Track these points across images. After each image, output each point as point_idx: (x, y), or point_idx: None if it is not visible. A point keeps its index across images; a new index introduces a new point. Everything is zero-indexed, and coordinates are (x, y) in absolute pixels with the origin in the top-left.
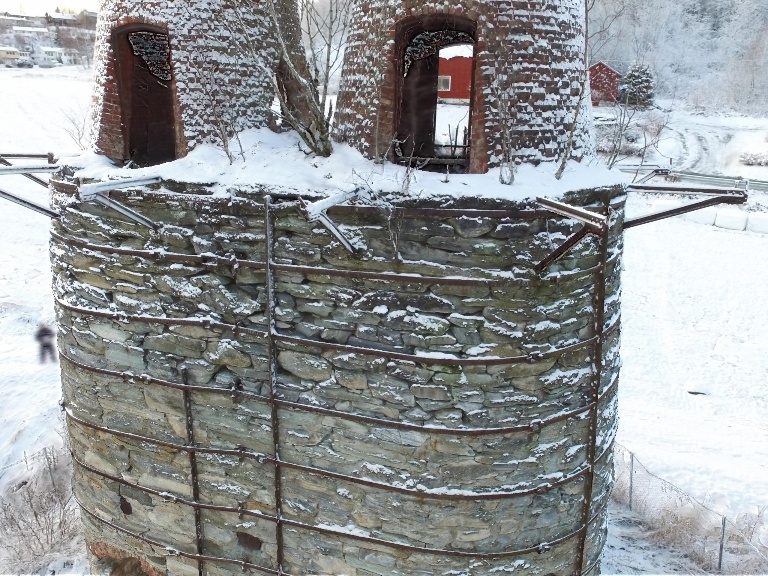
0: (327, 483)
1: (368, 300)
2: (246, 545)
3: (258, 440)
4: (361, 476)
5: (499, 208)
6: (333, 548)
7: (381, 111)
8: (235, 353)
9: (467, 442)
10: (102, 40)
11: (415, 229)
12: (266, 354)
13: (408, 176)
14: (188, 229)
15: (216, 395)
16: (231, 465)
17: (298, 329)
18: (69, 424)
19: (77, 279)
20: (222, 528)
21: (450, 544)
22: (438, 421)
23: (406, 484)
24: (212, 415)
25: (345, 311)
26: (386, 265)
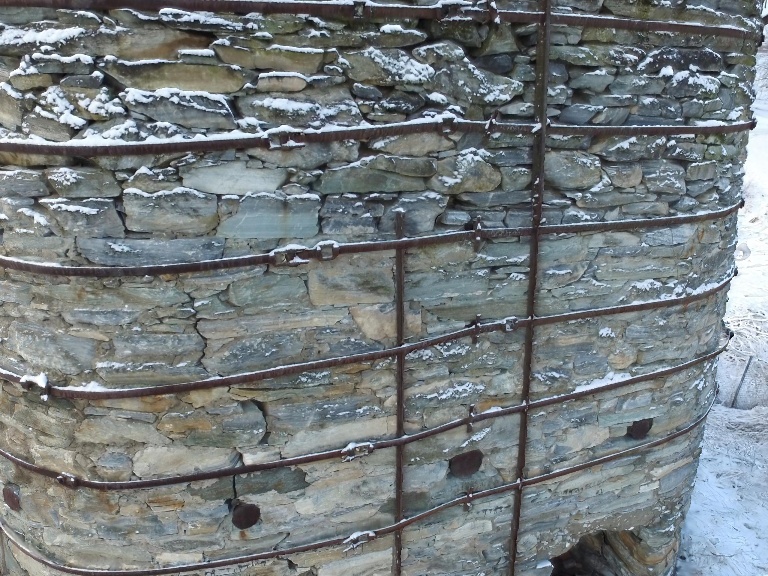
0: (589, 328)
1: (655, 60)
2: (461, 473)
3: (503, 300)
4: (630, 301)
5: None
6: (588, 413)
7: None
8: (484, 168)
9: (719, 226)
10: None
11: None
12: (525, 162)
13: None
14: None
15: (446, 247)
16: (461, 354)
17: (565, 117)
18: (69, 422)
19: (119, 89)
20: (433, 462)
21: (696, 352)
22: (707, 205)
23: (675, 293)
24: (438, 282)
25: (628, 79)
26: (670, 13)
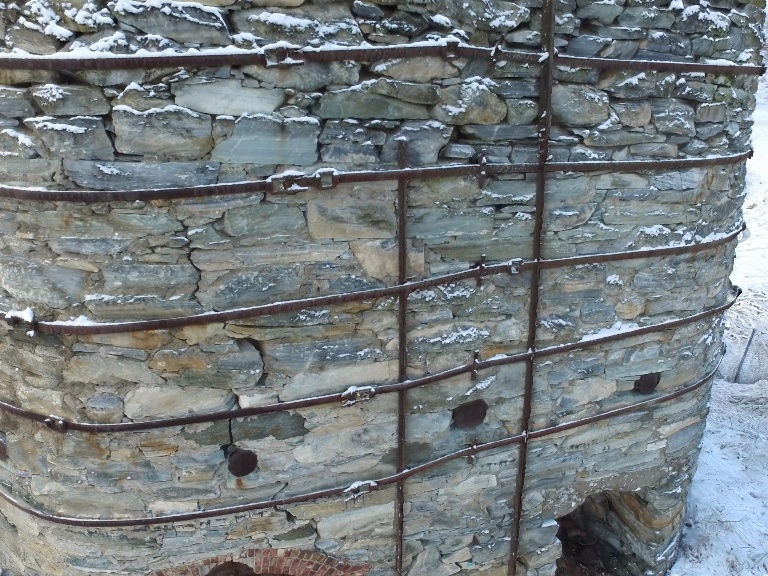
0: (596, 274)
1: None
2: (465, 424)
3: (509, 240)
4: (638, 247)
5: None
6: (595, 364)
7: None
8: (489, 98)
9: None
10: None
11: None
12: (531, 94)
13: None
14: None
15: (450, 181)
16: (465, 296)
17: (572, 48)
18: (56, 360)
19: None
20: (436, 411)
21: (704, 304)
22: (716, 149)
23: (684, 240)
24: (442, 218)
25: (637, 11)
26: None
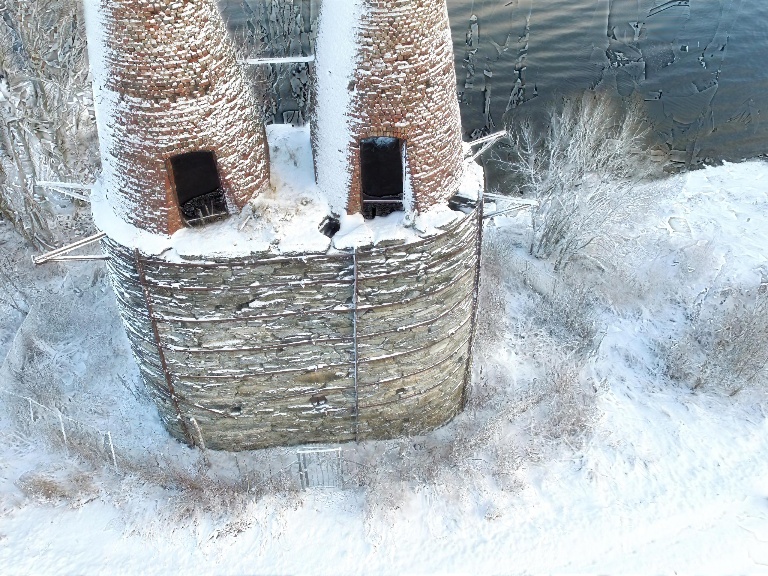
0: None
1: None
2: None
3: None
4: None
5: None
6: None
7: None
8: None
9: None
10: None
11: None
12: None
13: None
14: None
15: None
16: None
17: None
18: None
19: None
20: None
21: None
22: None
23: None
24: None
25: None
26: None
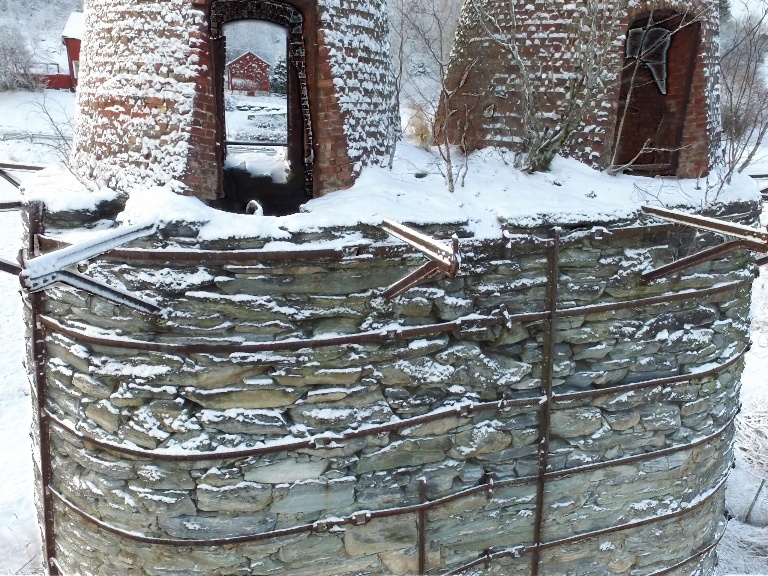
0: (590, 545)
1: (651, 328)
2: None
3: (513, 532)
4: (628, 520)
5: (748, 210)
6: None
7: (611, 116)
8: (496, 436)
9: None
10: (174, 4)
11: (695, 242)
12: (532, 424)
13: (721, 187)
14: (435, 288)
15: (463, 499)
16: None
17: (569, 382)
18: None
19: (196, 407)
20: None
21: (692, 548)
22: (701, 433)
23: (671, 508)
24: (455, 527)
25: (626, 346)
26: (666, 286)
